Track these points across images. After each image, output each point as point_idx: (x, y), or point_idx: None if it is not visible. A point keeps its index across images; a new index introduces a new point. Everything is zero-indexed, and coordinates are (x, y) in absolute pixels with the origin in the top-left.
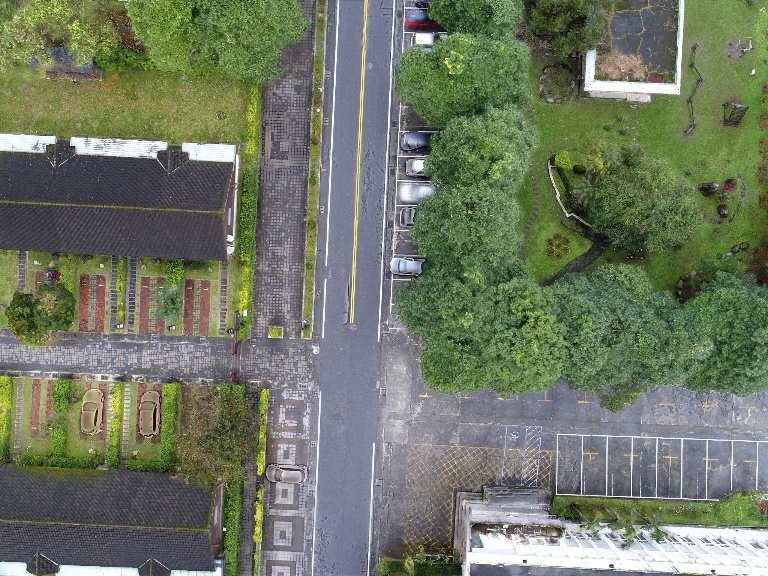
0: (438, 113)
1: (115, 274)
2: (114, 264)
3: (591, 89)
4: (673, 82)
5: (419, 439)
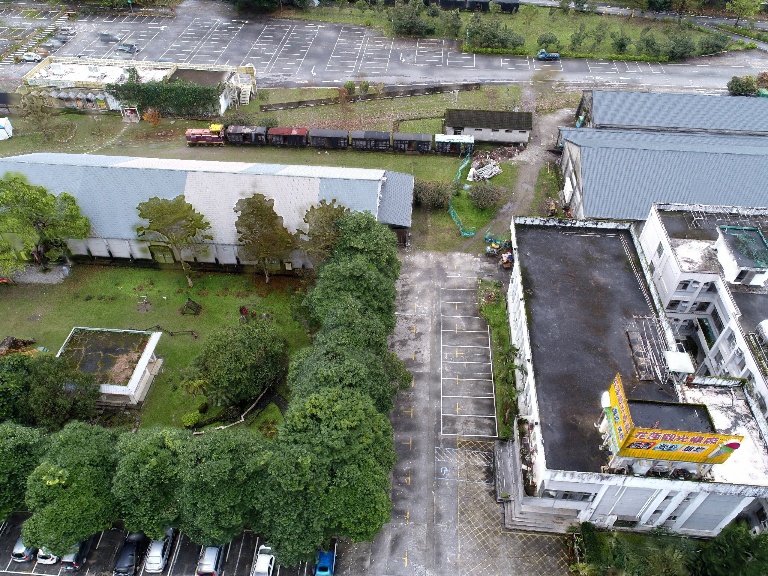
0: (101, 507)
1: None
2: None
3: (134, 390)
4: (150, 335)
5: (453, 569)
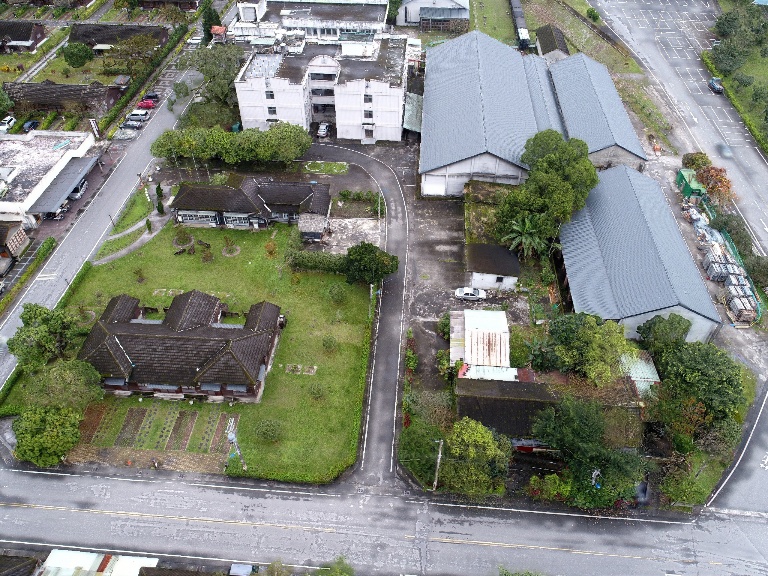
0: None
1: None
2: None
3: None
4: None
5: None
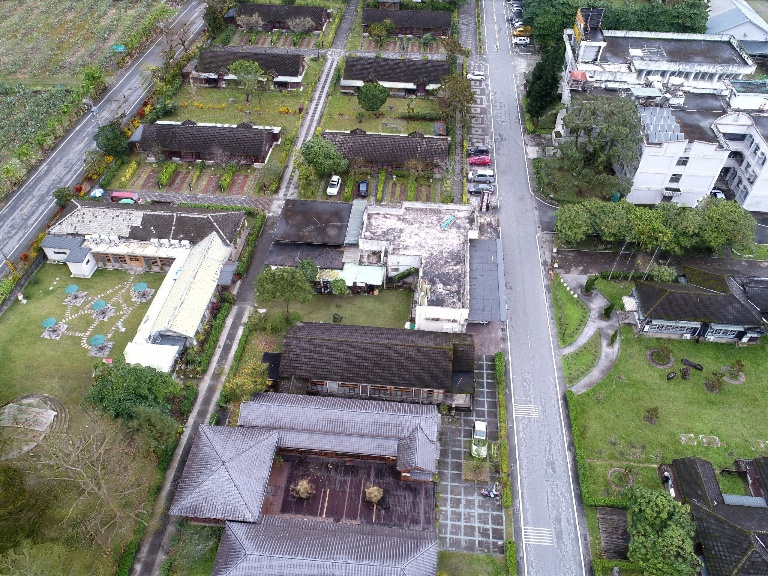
0: None
1: (401, 41)
2: (401, 39)
3: None
4: None
5: None
